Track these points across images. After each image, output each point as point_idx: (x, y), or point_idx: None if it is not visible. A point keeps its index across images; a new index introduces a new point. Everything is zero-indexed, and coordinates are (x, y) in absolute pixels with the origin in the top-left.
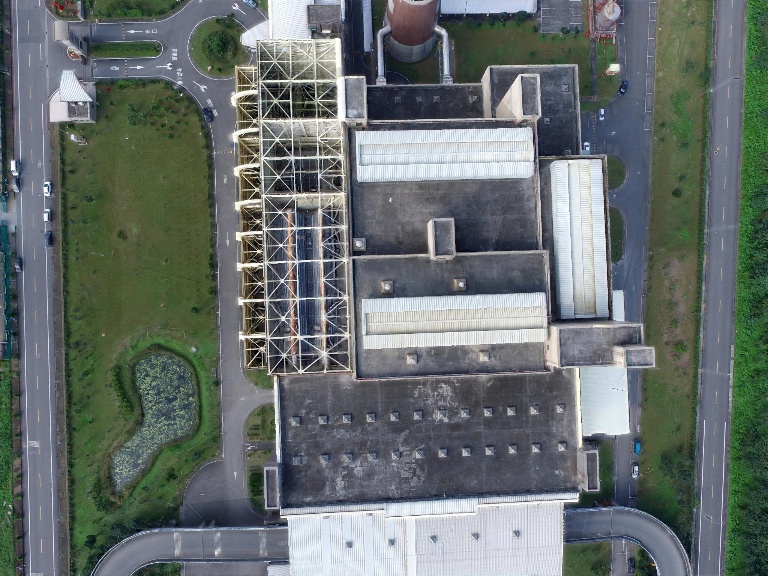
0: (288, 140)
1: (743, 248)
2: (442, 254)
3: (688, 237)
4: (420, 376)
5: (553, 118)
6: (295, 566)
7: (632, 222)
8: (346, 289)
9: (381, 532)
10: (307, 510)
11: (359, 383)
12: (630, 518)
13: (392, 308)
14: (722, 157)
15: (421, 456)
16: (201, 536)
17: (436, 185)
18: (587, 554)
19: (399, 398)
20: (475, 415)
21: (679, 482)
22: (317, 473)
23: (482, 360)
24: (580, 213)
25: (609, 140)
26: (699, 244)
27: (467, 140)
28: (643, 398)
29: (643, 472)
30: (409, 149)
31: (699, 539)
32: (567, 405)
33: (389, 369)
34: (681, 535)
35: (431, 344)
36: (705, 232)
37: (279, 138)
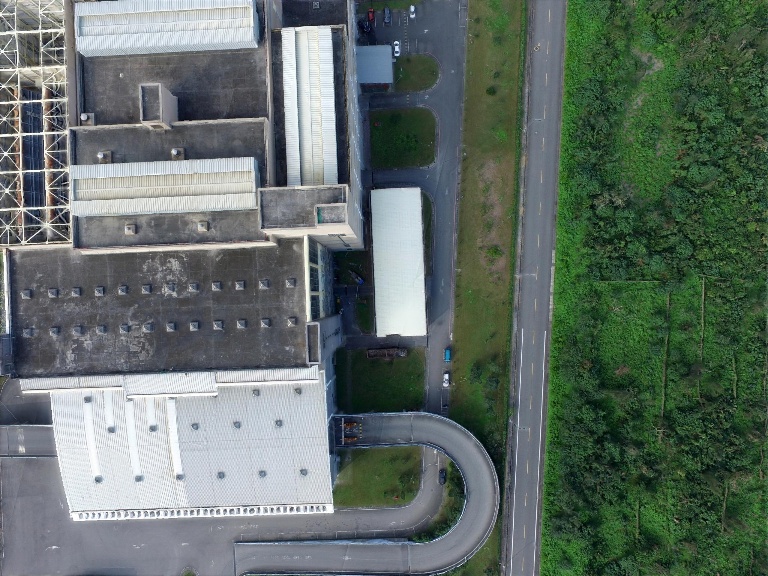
0: (11, 15)
1: (564, 148)
2: (150, 119)
3: (505, 137)
4: (137, 246)
5: (323, 2)
6: (61, 450)
7: (445, 123)
8: (67, 161)
9: (143, 418)
10: (47, 385)
11: (88, 257)
12: (432, 424)
13: (99, 174)
14: (543, 53)
15: (147, 329)
16: (6, 433)
17: (166, 59)
18: (396, 464)
19: (128, 272)
20: (204, 290)
21: (494, 392)
22: (48, 346)
23: (200, 230)
24: (309, 82)
25: (421, 38)
26: (515, 144)
27: (185, 7)
28: (456, 305)
29: (456, 381)
30: (129, 19)
31: (516, 452)
32: (298, 280)
33: (109, 240)
34: (489, 444)
35: (138, 210)
36: (524, 132)
37: (2, 13)
